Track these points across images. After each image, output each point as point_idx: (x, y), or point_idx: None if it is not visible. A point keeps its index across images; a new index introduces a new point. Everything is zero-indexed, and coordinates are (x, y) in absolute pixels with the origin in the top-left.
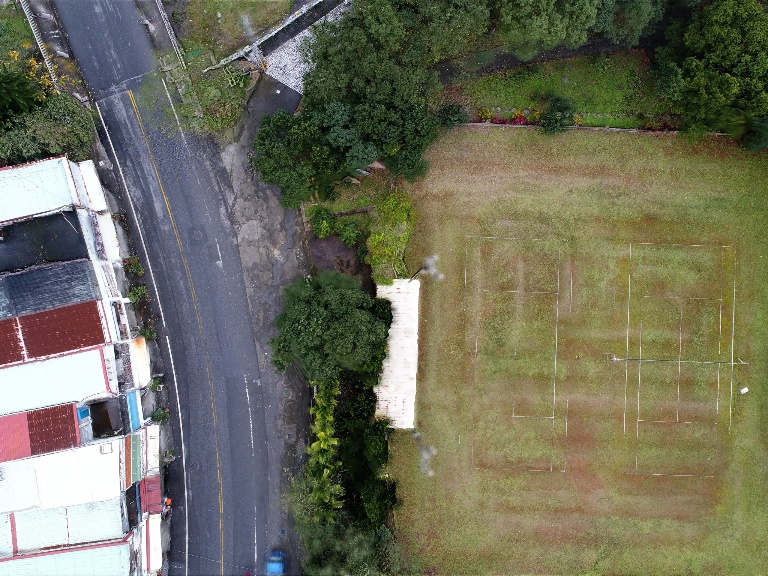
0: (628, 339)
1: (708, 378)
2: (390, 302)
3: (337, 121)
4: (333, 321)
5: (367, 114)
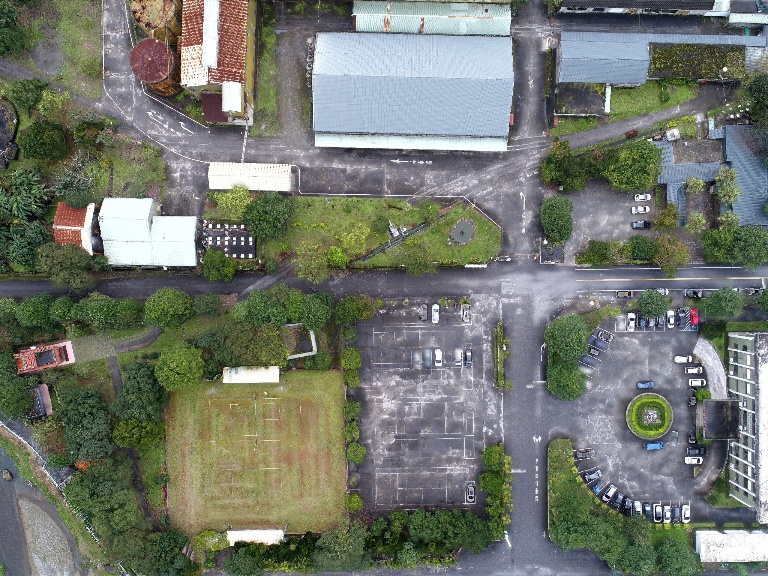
0: (248, 441)
1: (262, 408)
2: (235, 542)
3: (167, 575)
4: (238, 570)
5: (163, 567)
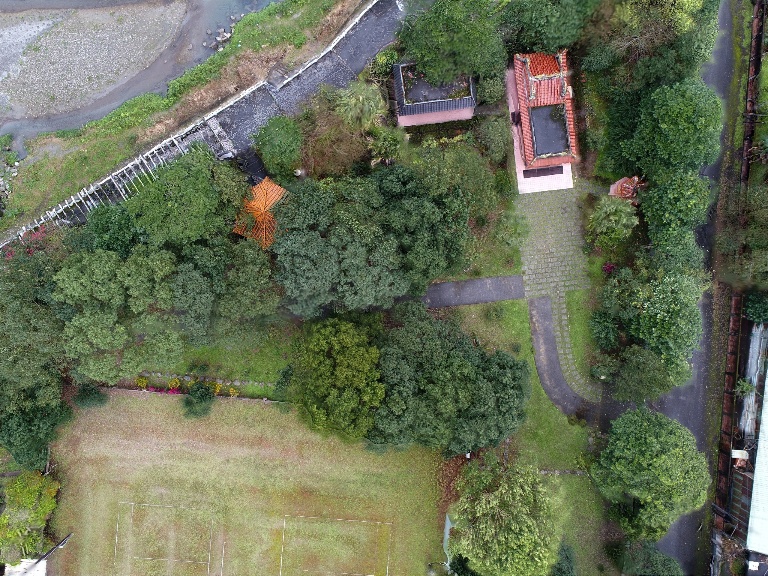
0: None
1: None
2: None
3: None
4: None
5: None
